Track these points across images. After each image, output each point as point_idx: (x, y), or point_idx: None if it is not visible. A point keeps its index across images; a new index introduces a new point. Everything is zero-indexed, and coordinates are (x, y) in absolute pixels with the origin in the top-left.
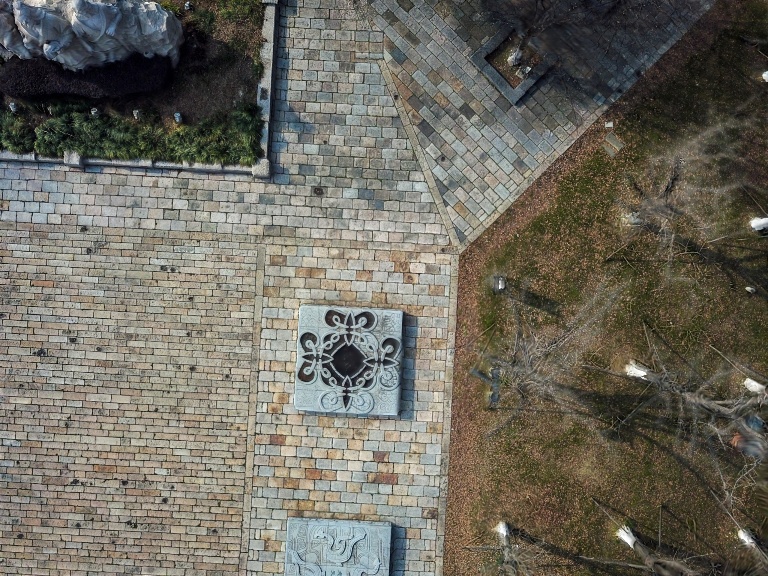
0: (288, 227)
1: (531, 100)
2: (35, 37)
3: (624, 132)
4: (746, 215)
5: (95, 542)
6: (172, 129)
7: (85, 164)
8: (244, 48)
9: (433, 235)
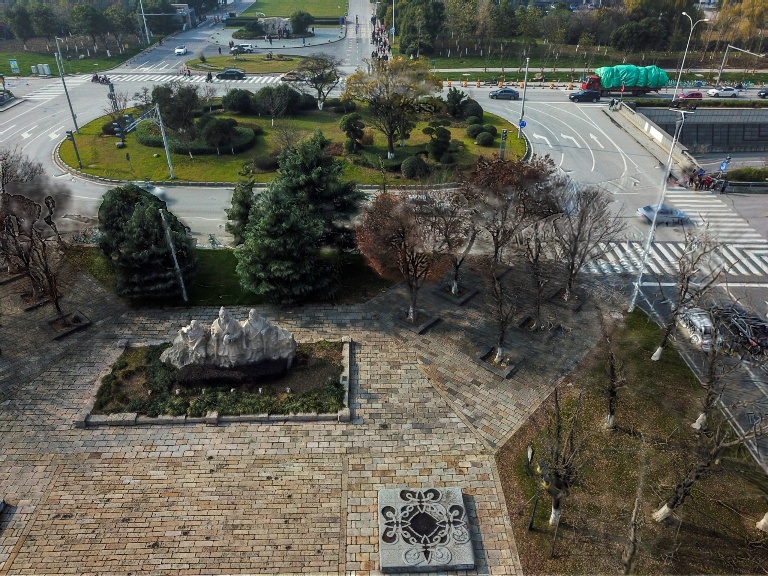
0: (364, 447)
1: (515, 376)
2: (222, 330)
3: (581, 387)
4: (686, 423)
5: None
6: None
7: (219, 421)
8: (331, 360)
9: (471, 445)
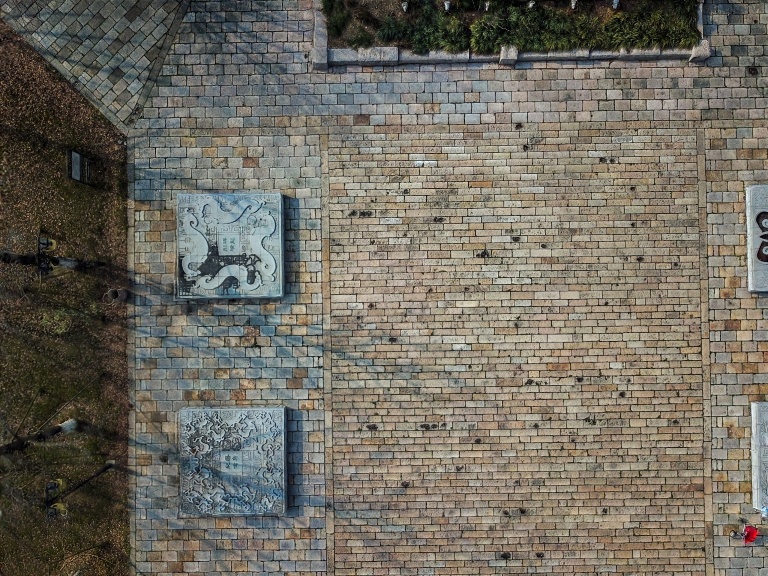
0: (725, 110)
1: None
2: None
3: None
4: None
5: (555, 441)
6: (607, 17)
7: (517, 60)
8: None
9: None
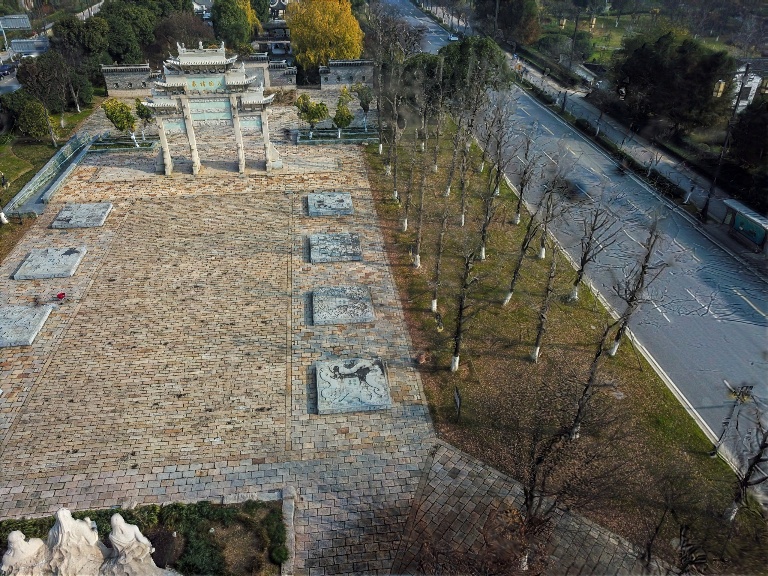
0: None
1: None
2: None
3: None
4: None
5: (158, 324)
6: None
7: None
8: None
9: None
